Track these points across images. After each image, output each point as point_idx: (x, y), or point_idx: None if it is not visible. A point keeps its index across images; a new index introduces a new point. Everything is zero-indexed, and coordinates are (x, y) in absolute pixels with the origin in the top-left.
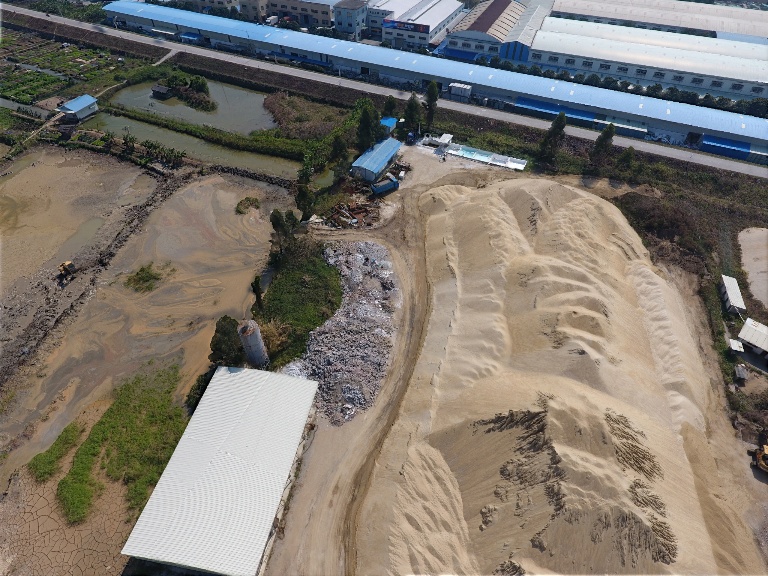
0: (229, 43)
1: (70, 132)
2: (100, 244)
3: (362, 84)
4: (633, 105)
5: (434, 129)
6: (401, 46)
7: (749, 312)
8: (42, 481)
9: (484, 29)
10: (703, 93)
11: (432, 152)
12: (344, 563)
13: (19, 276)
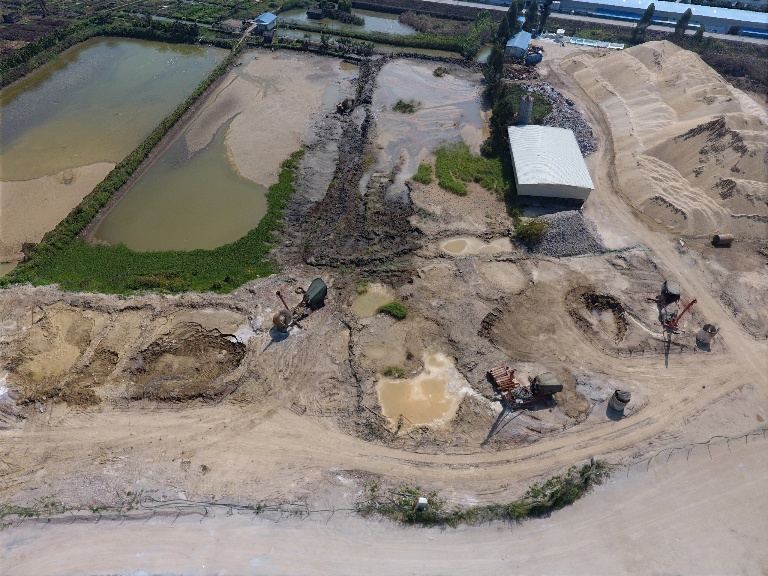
0: None
1: (272, 37)
2: (348, 97)
3: (473, 4)
4: None
5: (546, 28)
6: None
7: None
8: (427, 183)
9: None
10: None
11: (552, 41)
12: (623, 201)
13: (309, 113)
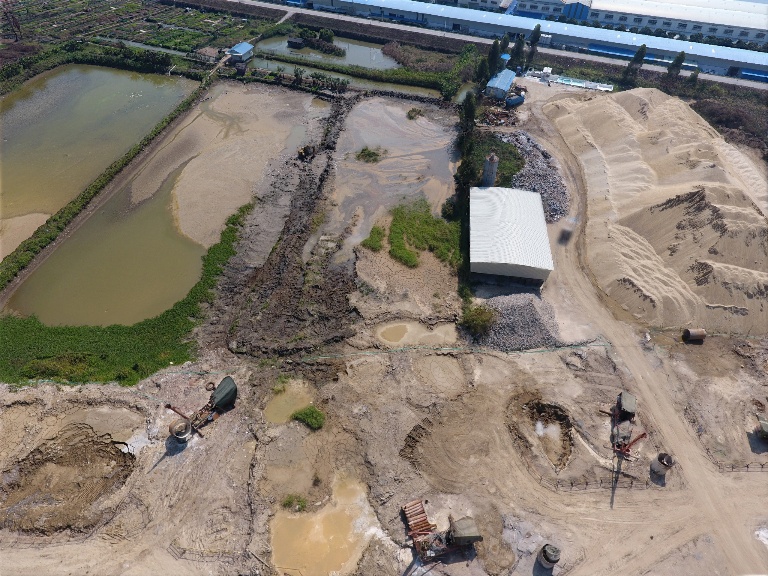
0: (331, 7)
1: (245, 69)
2: (314, 140)
3: (461, 35)
4: (685, 47)
5: (533, 65)
6: None
7: None
8: (377, 251)
9: None
10: None
11: (538, 80)
12: (589, 279)
13: (268, 158)
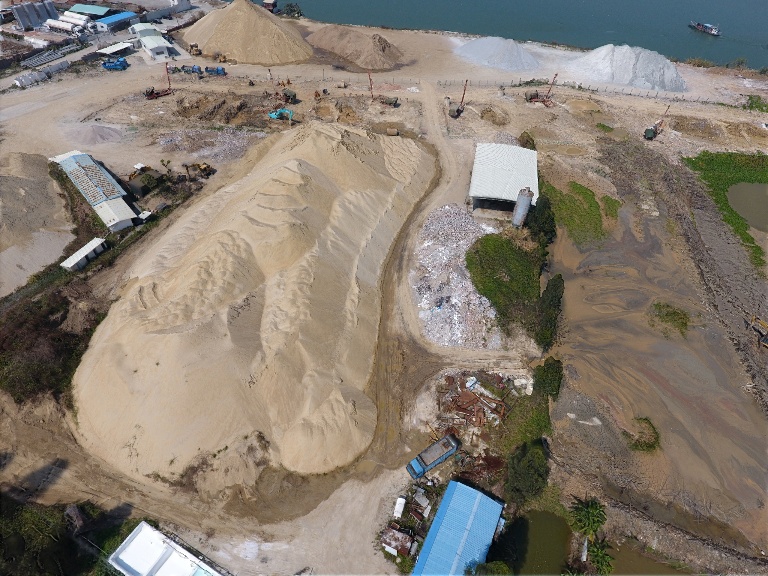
0: None
1: None
2: None
3: None
4: None
5: None
6: None
7: None
8: None
9: None
10: None
11: None
12: None
13: None
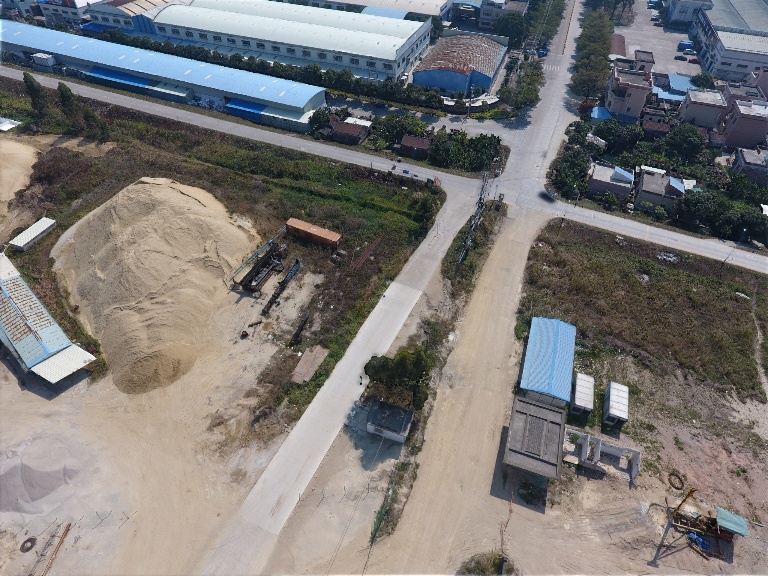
0: None
1: None
2: None
3: None
4: (181, 71)
5: None
6: (61, 22)
7: (36, 250)
8: None
9: (120, 3)
10: (295, 62)
11: None
12: None
13: None
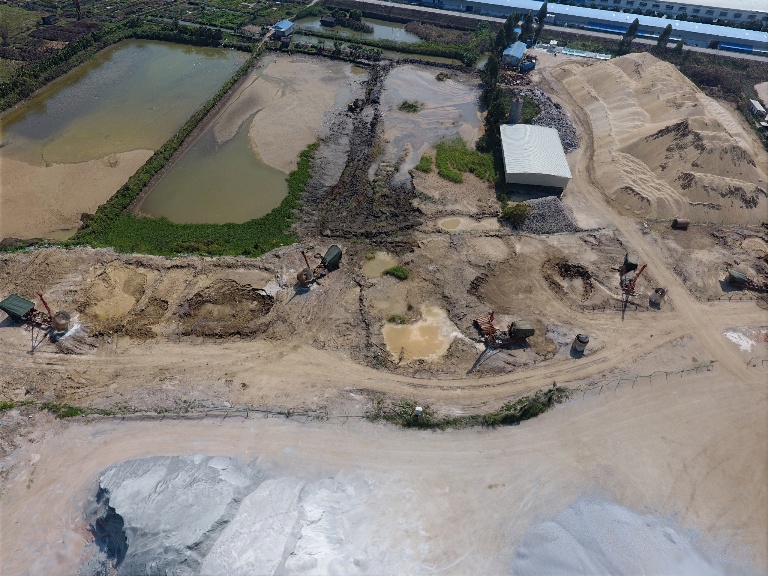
0: None
1: (289, 42)
2: (359, 98)
3: (475, 15)
4: (672, 24)
5: (541, 39)
6: None
7: None
8: (428, 172)
9: None
10: None
11: (545, 51)
12: (598, 190)
13: (323, 111)
